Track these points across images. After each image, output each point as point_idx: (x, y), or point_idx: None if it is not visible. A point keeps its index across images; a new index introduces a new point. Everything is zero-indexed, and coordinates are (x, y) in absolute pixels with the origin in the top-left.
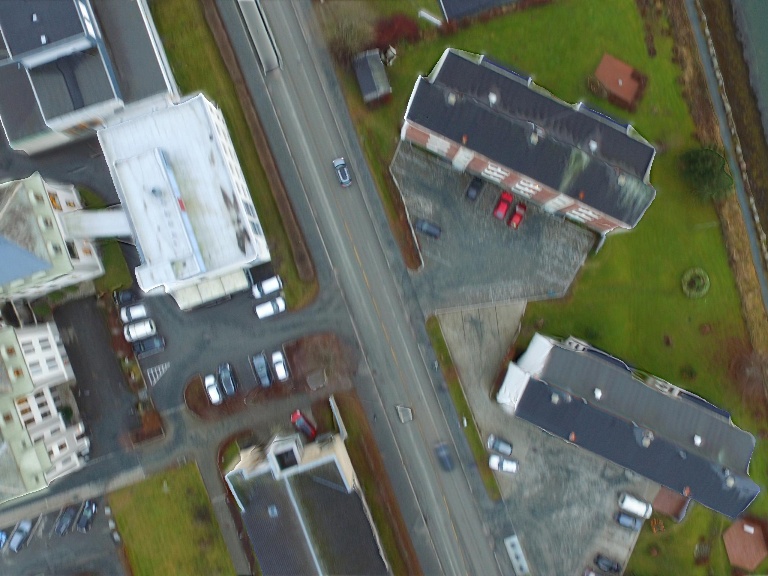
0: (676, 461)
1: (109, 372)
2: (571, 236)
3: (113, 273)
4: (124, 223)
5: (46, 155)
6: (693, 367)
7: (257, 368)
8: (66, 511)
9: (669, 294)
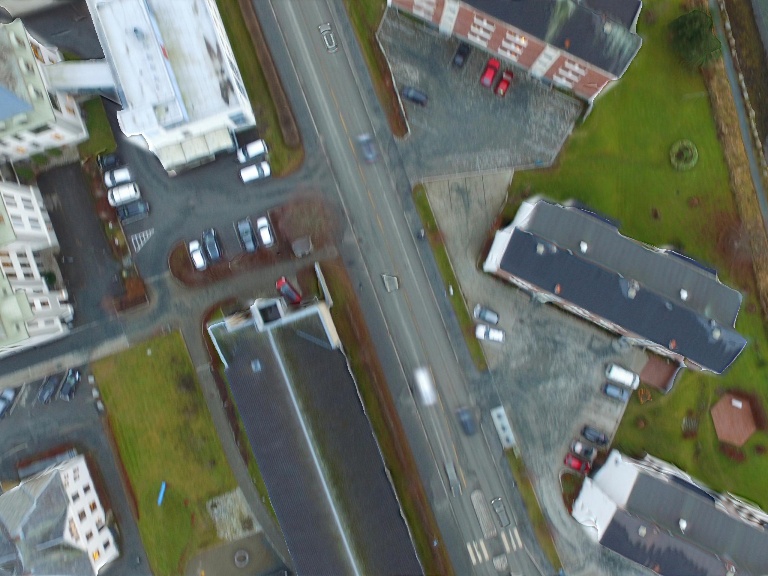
0: (662, 313)
1: (93, 239)
2: (558, 105)
3: (97, 137)
4: (107, 74)
5: (30, 17)
6: (681, 240)
7: (242, 233)
8: (49, 379)
9: (657, 167)
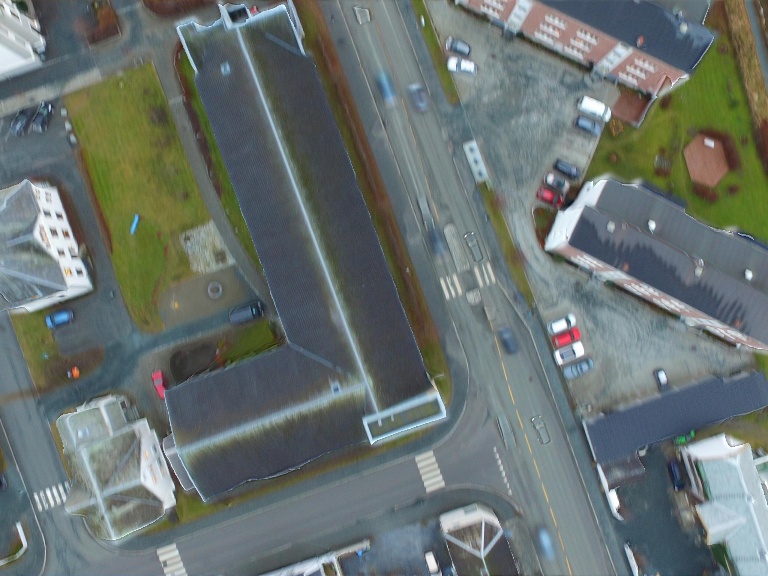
0: (629, 8)
1: None
2: None
3: None
4: None
5: None
6: None
7: None
8: (22, 113)
9: None
